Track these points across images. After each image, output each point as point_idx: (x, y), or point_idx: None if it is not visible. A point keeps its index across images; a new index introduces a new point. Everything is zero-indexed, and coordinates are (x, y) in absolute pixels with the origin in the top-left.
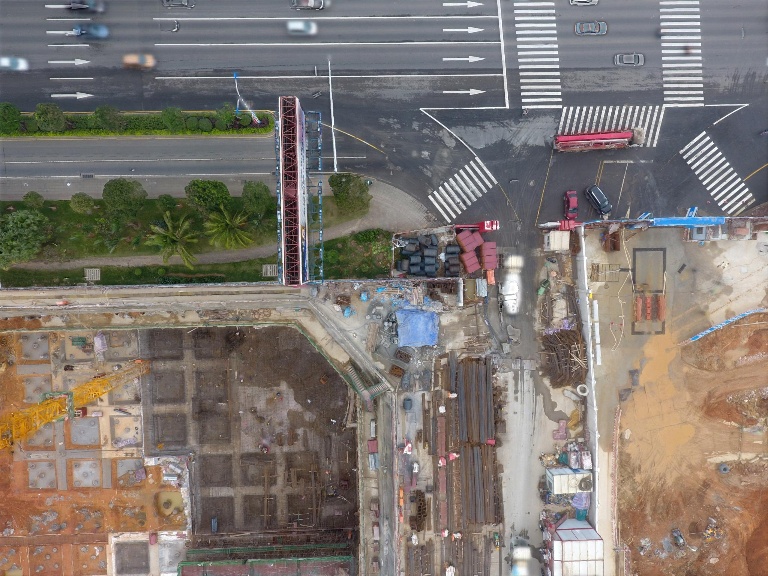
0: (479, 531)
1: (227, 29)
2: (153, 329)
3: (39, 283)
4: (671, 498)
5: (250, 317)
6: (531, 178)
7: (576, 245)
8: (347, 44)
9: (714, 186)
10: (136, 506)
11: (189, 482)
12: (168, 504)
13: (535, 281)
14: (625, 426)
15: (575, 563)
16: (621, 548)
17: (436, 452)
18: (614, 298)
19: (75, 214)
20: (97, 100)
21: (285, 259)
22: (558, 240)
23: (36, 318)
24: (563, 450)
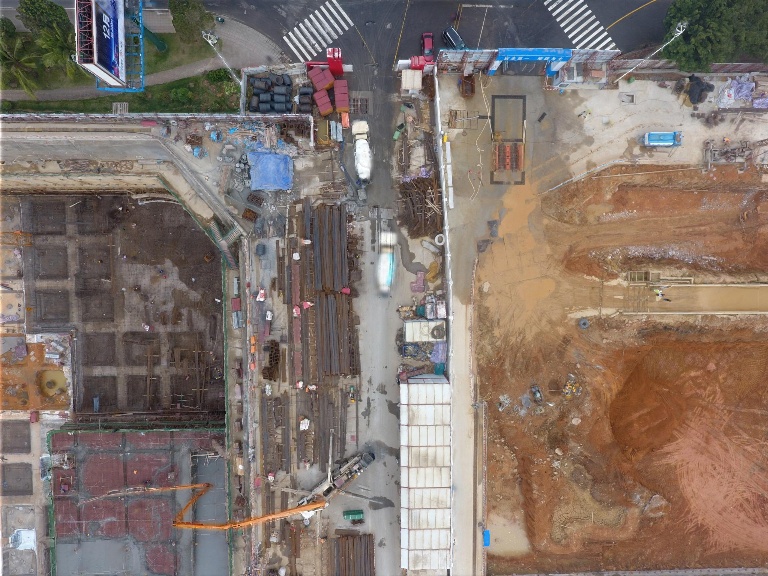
0: (335, 384)
1: None
2: (36, 203)
3: None
4: (531, 354)
5: (112, 169)
6: (388, 21)
7: (432, 88)
8: None
9: (576, 34)
10: (17, 384)
11: (71, 360)
12: (51, 384)
13: (392, 127)
14: (484, 278)
15: (421, 406)
16: (480, 405)
17: (291, 302)
18: (472, 146)
19: None
20: None
21: (78, 36)
22: (410, 79)
23: None
24: (421, 303)
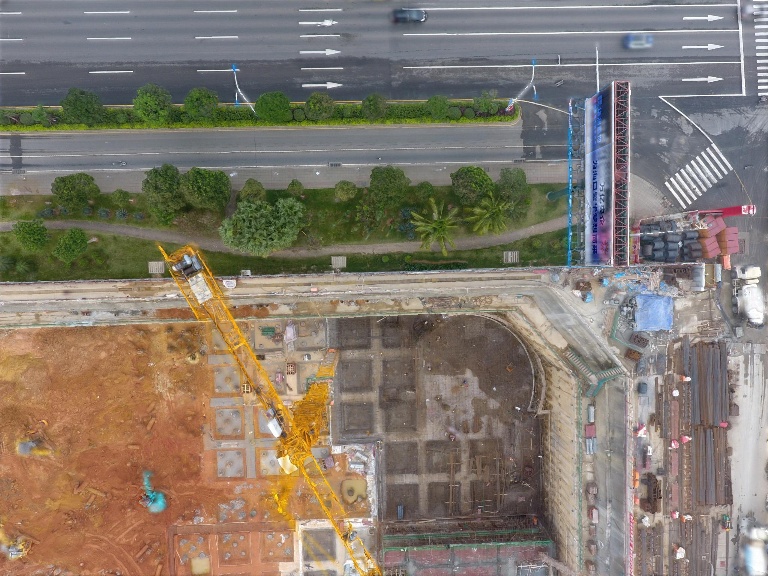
0: (707, 513)
1: (474, 19)
2: (341, 319)
3: (287, 271)
4: None
5: (472, 304)
6: (765, 164)
7: None
8: (590, 33)
9: None
10: (323, 494)
11: (376, 470)
12: (353, 492)
13: (767, 266)
14: None
15: None
16: None
17: (667, 435)
18: None
19: (323, 202)
20: (346, 90)
21: (614, 241)
22: None
23: (264, 306)
24: None
